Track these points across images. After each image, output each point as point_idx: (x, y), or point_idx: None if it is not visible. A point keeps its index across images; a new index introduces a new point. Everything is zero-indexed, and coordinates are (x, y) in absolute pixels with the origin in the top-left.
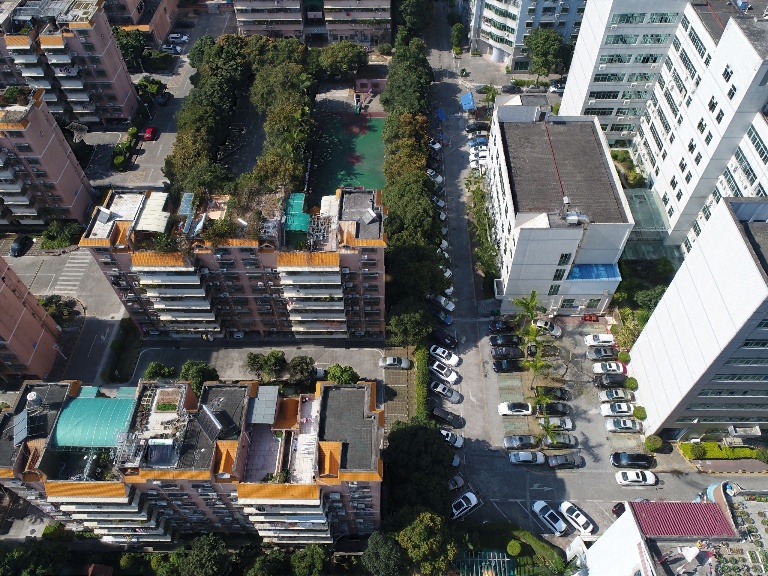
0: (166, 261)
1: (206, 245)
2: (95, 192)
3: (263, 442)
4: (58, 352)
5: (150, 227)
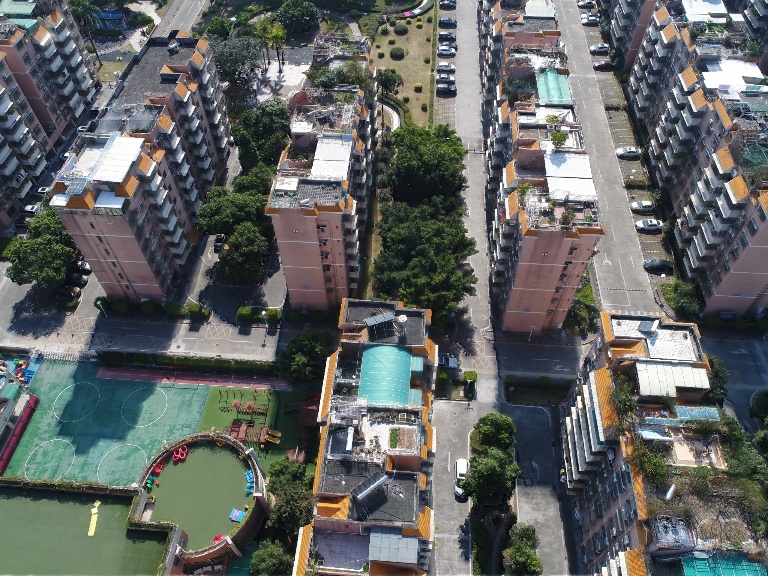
0: (605, 406)
1: (628, 449)
2: (759, 313)
3: (361, 550)
4: (535, 332)
5: (644, 378)
